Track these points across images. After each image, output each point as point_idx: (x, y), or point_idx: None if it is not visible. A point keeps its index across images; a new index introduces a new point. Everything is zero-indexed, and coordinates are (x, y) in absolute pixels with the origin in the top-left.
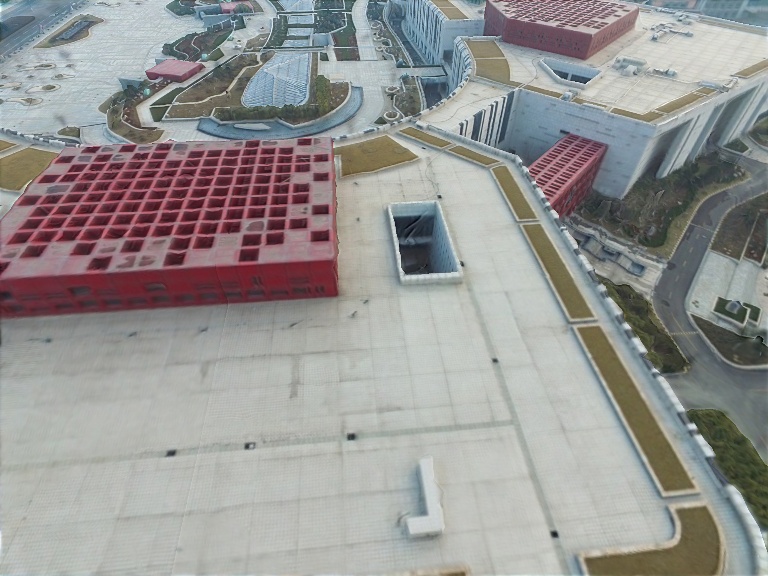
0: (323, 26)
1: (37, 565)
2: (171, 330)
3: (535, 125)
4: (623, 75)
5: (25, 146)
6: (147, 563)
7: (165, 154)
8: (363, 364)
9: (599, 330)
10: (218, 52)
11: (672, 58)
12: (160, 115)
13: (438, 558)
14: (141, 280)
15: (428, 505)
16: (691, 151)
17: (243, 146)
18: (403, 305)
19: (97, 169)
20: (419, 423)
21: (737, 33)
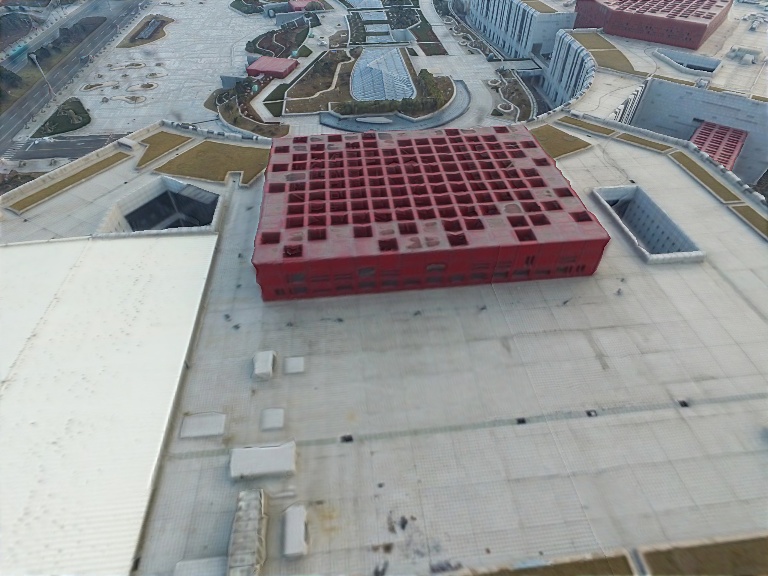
0: (400, 22)
1: (459, 522)
2: (452, 309)
3: (665, 114)
4: (742, 64)
5: (200, 139)
6: None
7: (374, 143)
8: (655, 337)
9: None
10: (305, 49)
11: None
12: (278, 110)
13: None
14: (427, 260)
15: None
16: None
17: (445, 134)
18: (660, 283)
19: (319, 158)
20: (740, 390)
21: None
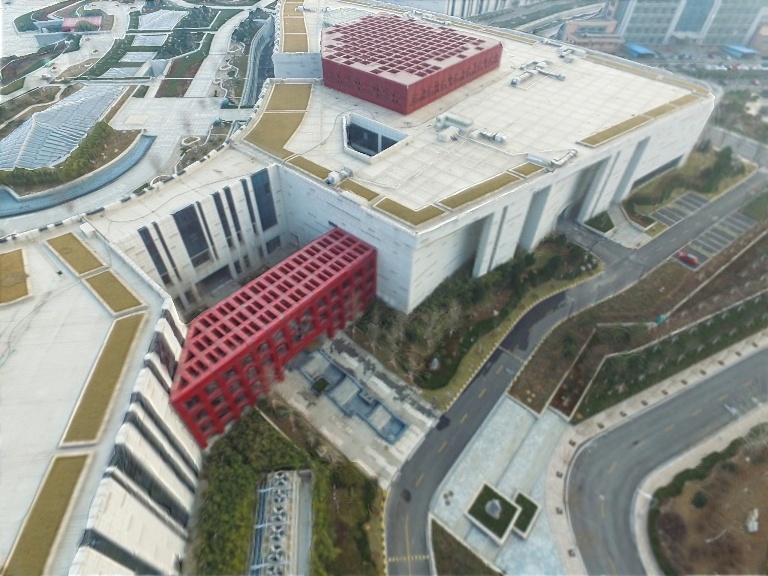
0: (166, 50)
1: None
2: None
3: (304, 210)
4: (439, 140)
5: None
6: None
7: None
8: None
9: None
10: (18, 83)
11: (518, 113)
12: None
13: None
14: None
15: None
16: (519, 241)
17: None
18: None
19: None
20: None
21: (622, 75)
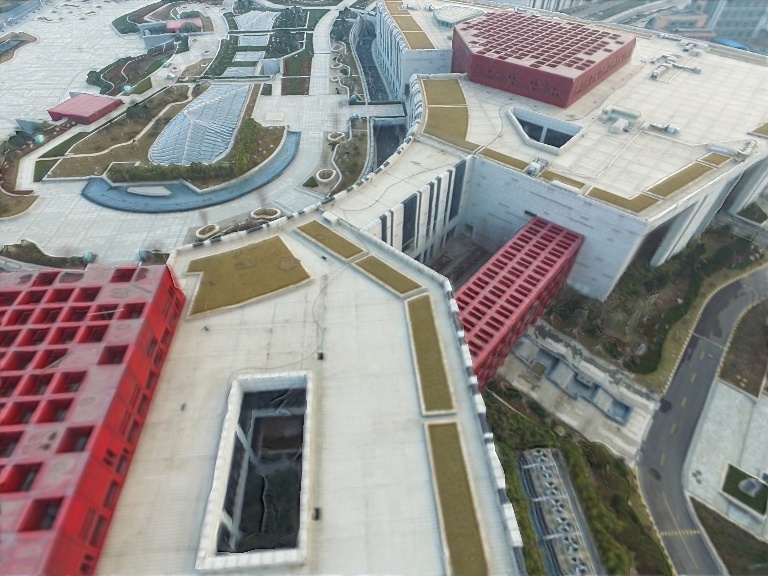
0: (275, 50)
1: None
2: None
3: (494, 201)
4: (611, 132)
5: None
6: None
7: None
8: None
9: None
10: (146, 83)
11: (674, 106)
12: (43, 172)
13: None
14: None
15: None
16: (696, 231)
17: (29, 284)
18: None
19: None
20: None
21: (755, 68)
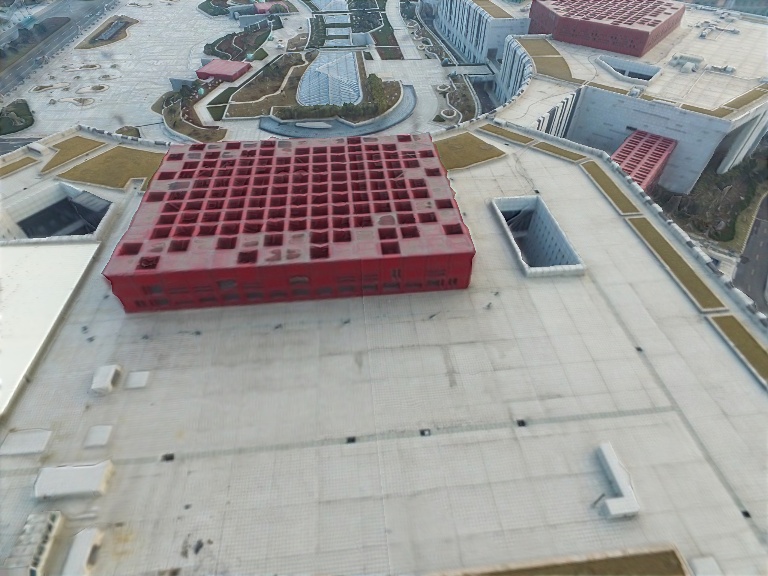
0: (361, 25)
1: (255, 547)
2: (315, 322)
3: (600, 122)
4: (682, 72)
5: (113, 145)
6: (361, 544)
7: (271, 151)
8: (512, 353)
9: (734, 319)
10: (262, 52)
11: (725, 55)
12: (219, 114)
13: (642, 537)
14: (287, 273)
15: (620, 487)
16: (751, 147)
17: (345, 143)
18: (534, 297)
19: (210, 166)
20: (583, 410)
21: None
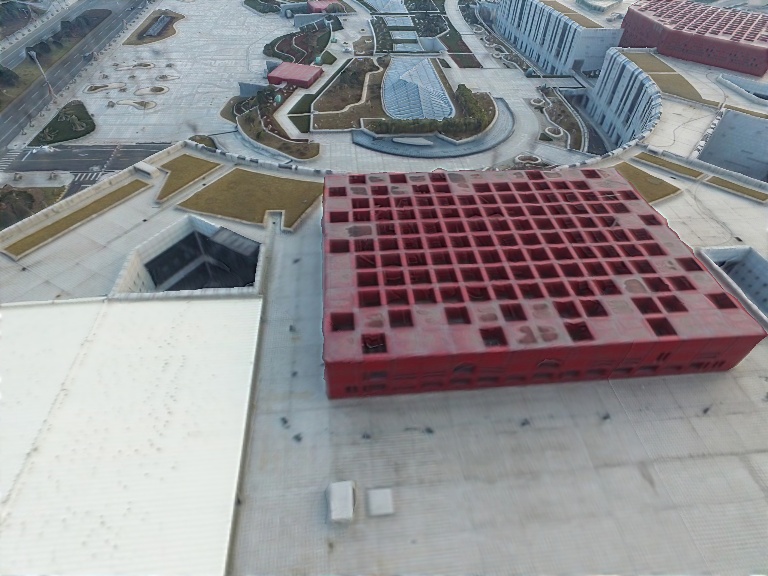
0: (428, 29)
1: None
2: (567, 417)
3: (737, 149)
4: None
5: (229, 166)
6: None
7: (445, 186)
8: None
9: None
10: (329, 55)
11: None
12: (305, 125)
13: None
14: (541, 357)
15: None
16: None
17: (526, 178)
18: None
19: (384, 205)
20: None
21: None
